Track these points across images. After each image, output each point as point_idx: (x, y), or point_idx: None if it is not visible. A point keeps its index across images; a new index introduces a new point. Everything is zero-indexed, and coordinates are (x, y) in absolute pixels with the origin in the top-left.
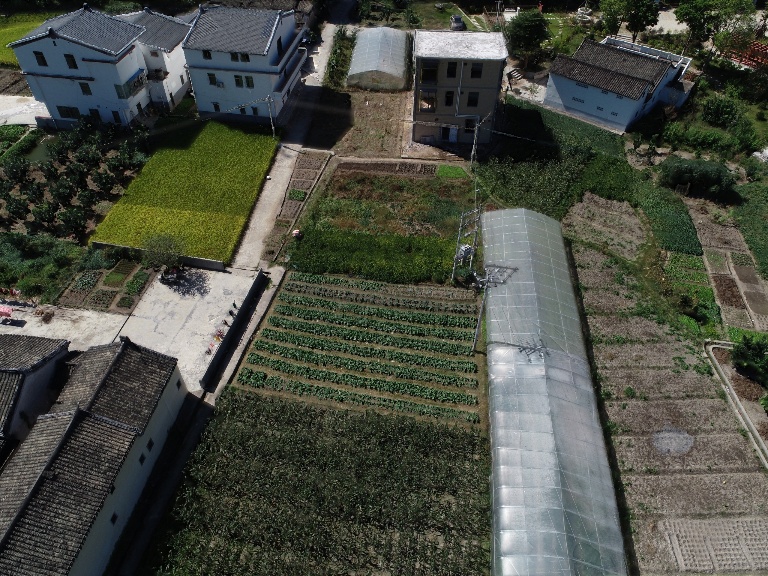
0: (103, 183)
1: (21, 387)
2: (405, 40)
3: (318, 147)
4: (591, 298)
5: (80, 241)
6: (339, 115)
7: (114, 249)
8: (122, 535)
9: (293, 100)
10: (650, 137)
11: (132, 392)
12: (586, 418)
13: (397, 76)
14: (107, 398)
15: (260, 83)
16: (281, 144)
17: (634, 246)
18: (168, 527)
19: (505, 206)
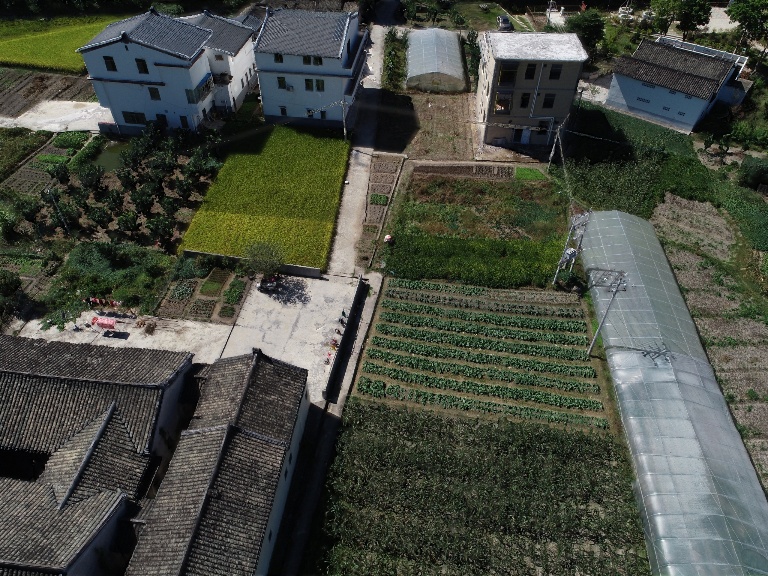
0: (184, 190)
1: (161, 402)
2: (458, 41)
3: (389, 150)
4: (694, 300)
5: (167, 250)
6: (404, 118)
7: (206, 257)
8: (274, 552)
9: (355, 103)
10: (718, 137)
11: (272, 405)
12: (723, 422)
13: (458, 78)
14: (250, 412)
15: (331, 86)
16: (352, 148)
17: (725, 247)
18: (320, 543)
19: None
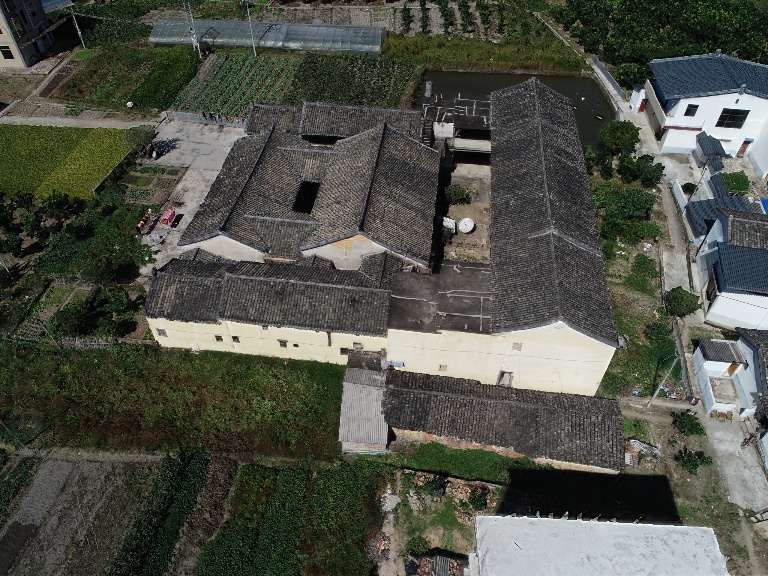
0: (1, 195)
1: None
2: None
3: None
4: None
5: (76, 213)
6: None
7: None
8: None
9: None
10: None
11: None
12: None
13: None
14: None
15: None
16: None
17: None
18: None
19: (136, 41)
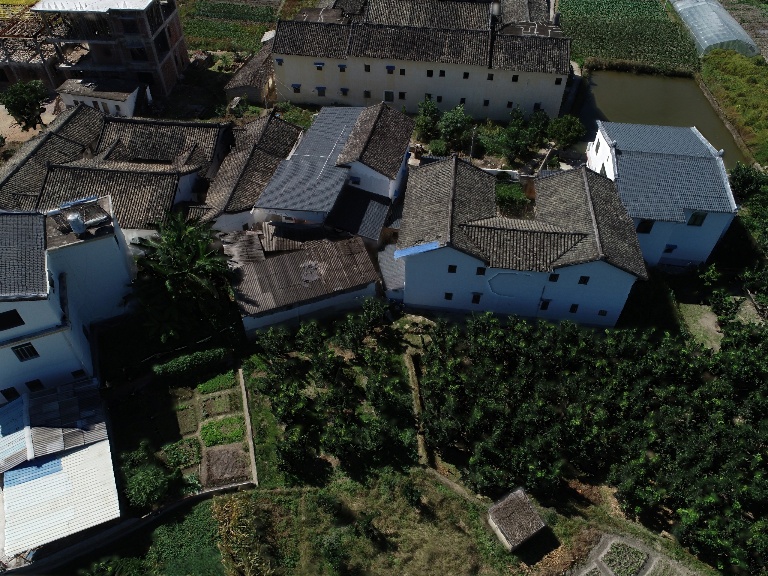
0: None
1: None
2: None
3: None
4: None
5: None
6: None
7: None
8: None
9: None
10: None
11: None
12: (728, 15)
13: None
14: None
15: None
16: None
17: None
18: None
19: None
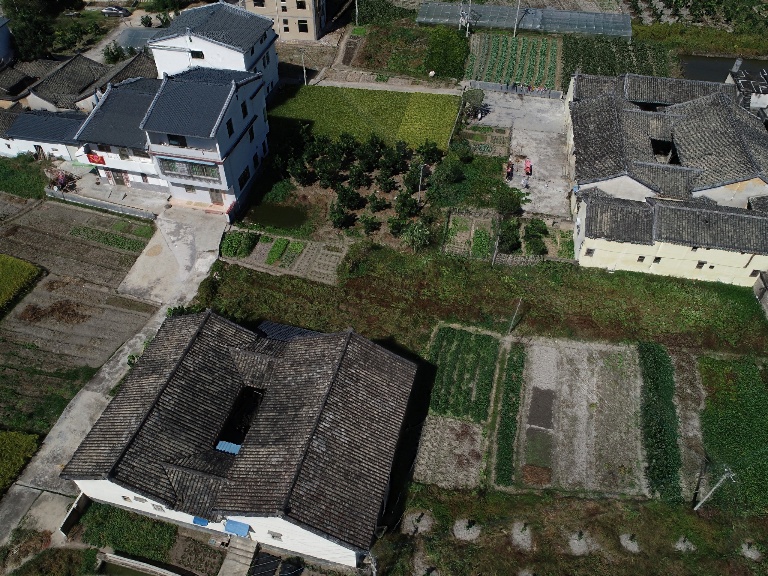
0: None
1: None
2: None
3: (313, 75)
4: None
5: None
6: None
7: None
8: None
9: None
10: None
11: None
12: None
13: None
14: None
15: (271, 54)
16: None
17: None
18: None
19: None
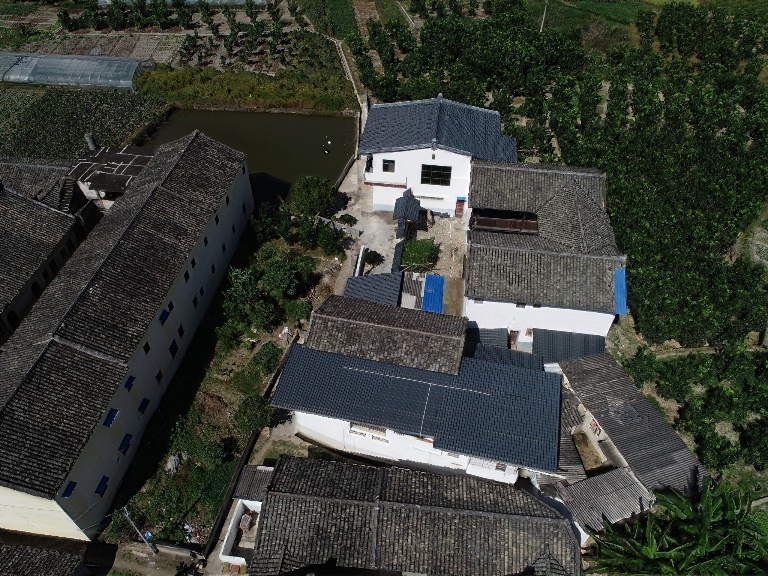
0: None
1: None
2: None
3: None
4: None
5: None
6: None
7: None
8: None
9: None
10: None
11: None
12: None
13: None
14: None
15: None
16: None
17: None
18: None
19: None
